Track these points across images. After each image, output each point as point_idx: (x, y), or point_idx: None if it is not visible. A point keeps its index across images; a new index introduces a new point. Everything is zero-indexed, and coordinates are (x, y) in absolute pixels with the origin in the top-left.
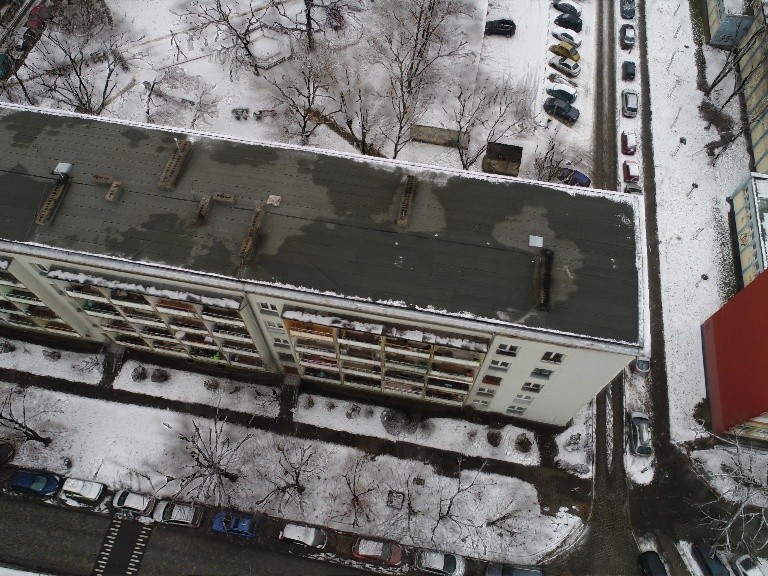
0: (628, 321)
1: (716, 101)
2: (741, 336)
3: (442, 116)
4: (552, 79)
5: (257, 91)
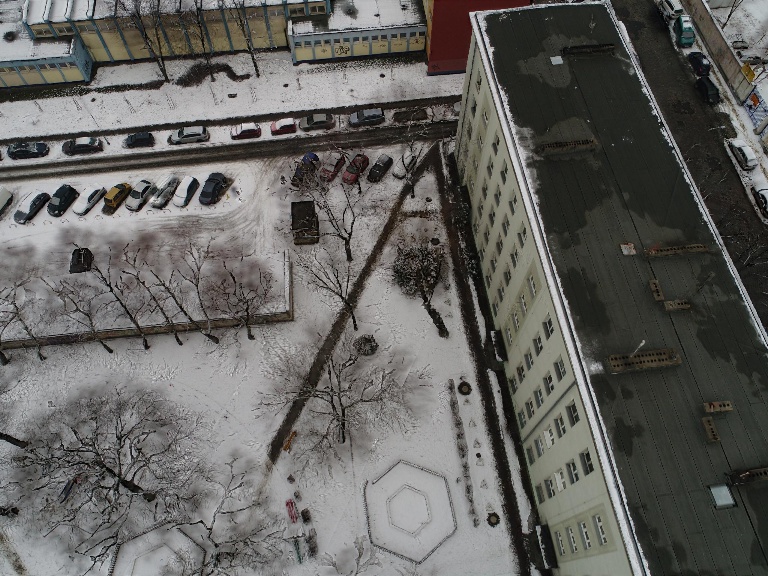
0: (591, 10)
1: (174, 75)
2: (466, 29)
3: None
4: (162, 205)
5: None
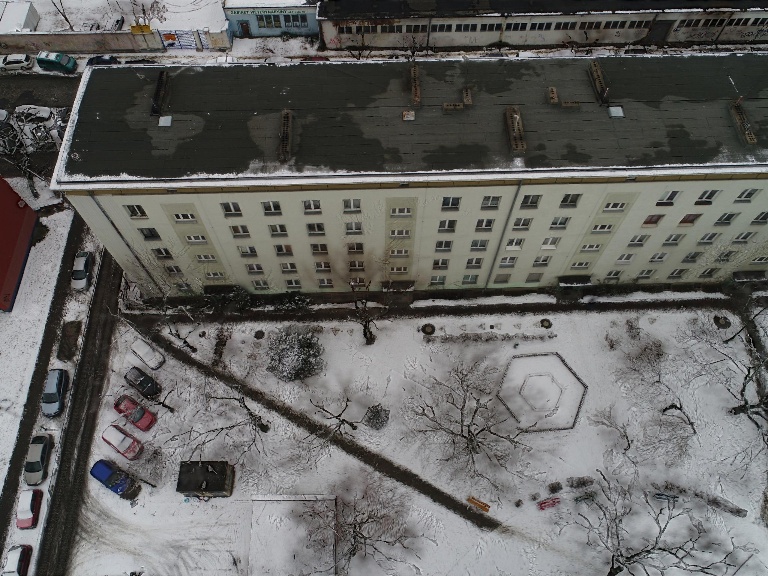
0: (97, 80)
1: None
2: None
3: (293, 526)
4: None
5: (583, 548)
